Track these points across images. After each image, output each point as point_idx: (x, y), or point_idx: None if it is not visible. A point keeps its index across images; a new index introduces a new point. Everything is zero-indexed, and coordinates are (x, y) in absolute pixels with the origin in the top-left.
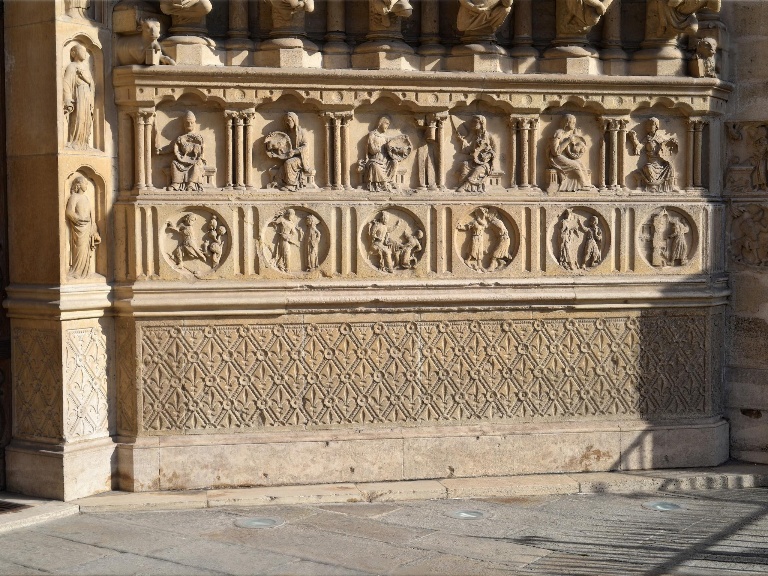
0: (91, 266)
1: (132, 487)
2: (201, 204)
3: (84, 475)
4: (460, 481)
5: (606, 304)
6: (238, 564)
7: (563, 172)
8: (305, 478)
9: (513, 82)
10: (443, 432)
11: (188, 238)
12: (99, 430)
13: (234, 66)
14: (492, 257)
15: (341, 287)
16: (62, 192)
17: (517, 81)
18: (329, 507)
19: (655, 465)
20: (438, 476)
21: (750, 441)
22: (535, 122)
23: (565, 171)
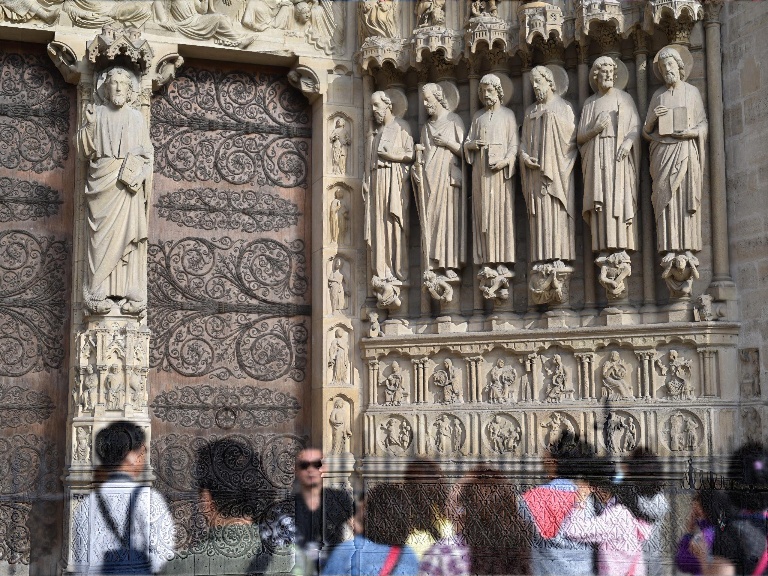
0: (347, 448)
1: (360, 574)
2: (397, 413)
3: (333, 564)
4: None
5: (638, 476)
6: None
7: (610, 388)
8: None
9: (571, 333)
10: (532, 556)
11: (391, 433)
12: (348, 541)
13: (419, 334)
14: (563, 444)
15: (471, 462)
16: (325, 408)
17: (573, 332)
18: None
19: None
20: None
21: None
22: (592, 357)
23: (612, 388)
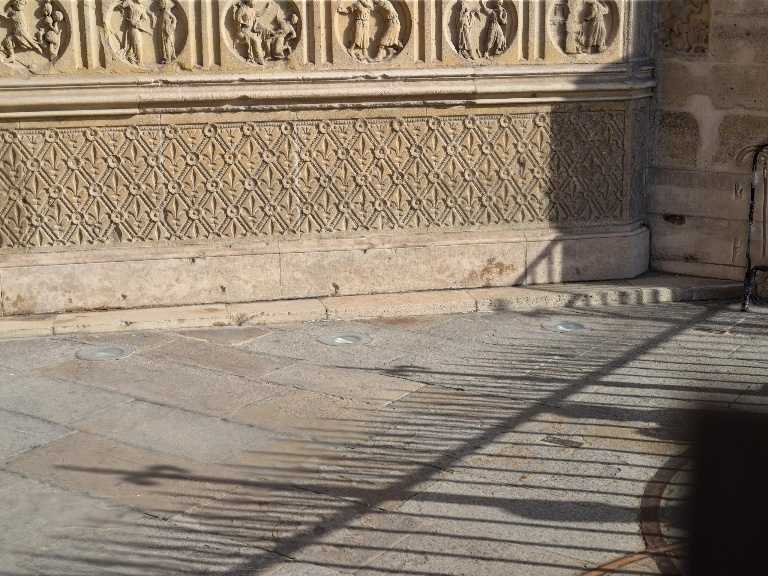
0: None
1: None
2: None
3: None
4: (344, 300)
5: (511, 98)
6: (60, 406)
7: None
8: (169, 299)
9: None
10: (325, 246)
11: (18, 26)
12: None
13: None
14: (379, 45)
15: (202, 82)
16: None
17: None
18: (191, 332)
19: (565, 278)
20: (321, 294)
21: (672, 250)
22: None
23: None
